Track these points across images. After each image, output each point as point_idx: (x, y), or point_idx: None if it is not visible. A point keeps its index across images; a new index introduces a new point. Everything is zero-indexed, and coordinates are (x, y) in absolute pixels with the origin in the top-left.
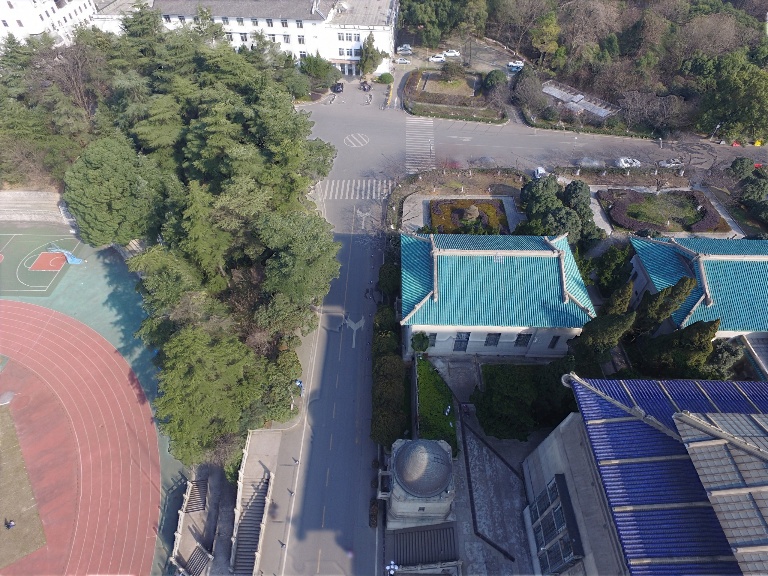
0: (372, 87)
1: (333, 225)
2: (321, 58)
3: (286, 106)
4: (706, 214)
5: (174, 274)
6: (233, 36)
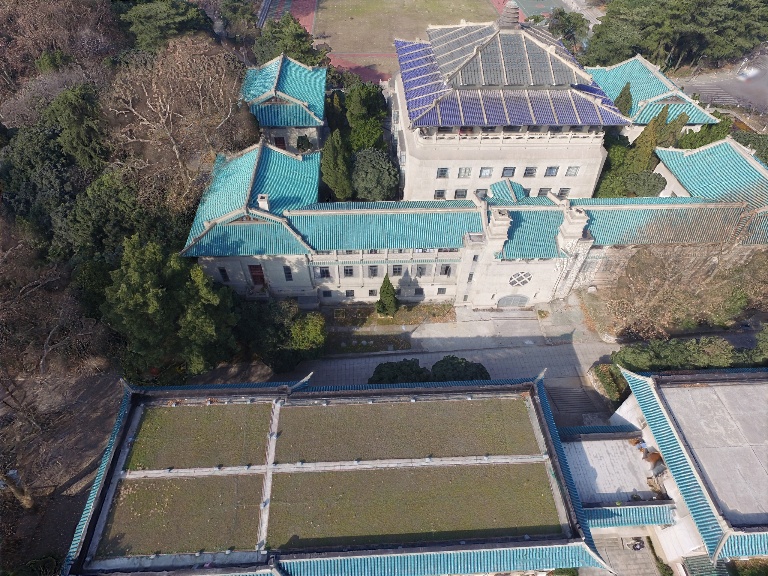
0: None
1: None
2: None
3: (726, 1)
4: None
5: (570, 16)
6: None
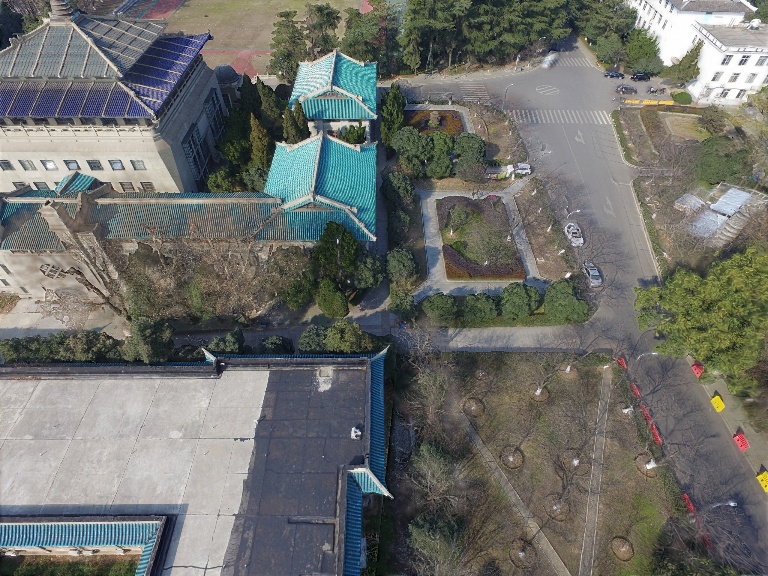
0: (657, 93)
1: (371, 37)
2: (653, 44)
3: None
4: (471, 261)
5: (335, 12)
6: (642, 2)
